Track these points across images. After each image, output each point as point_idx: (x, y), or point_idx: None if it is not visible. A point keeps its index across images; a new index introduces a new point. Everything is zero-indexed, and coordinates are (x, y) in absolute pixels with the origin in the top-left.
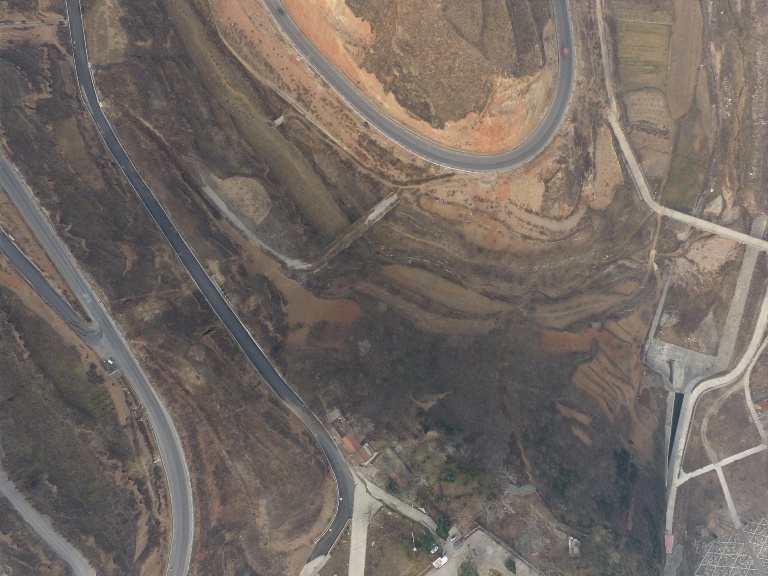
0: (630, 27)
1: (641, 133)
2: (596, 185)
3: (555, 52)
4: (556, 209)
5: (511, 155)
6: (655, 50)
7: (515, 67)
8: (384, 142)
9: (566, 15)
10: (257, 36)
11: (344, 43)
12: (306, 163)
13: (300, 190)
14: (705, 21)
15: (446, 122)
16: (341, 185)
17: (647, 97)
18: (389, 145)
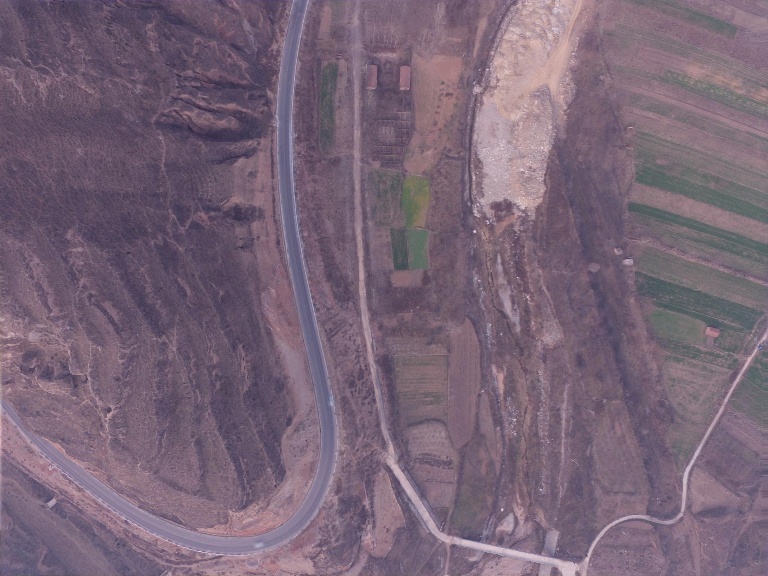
0: (407, 361)
1: (424, 466)
2: (376, 532)
3: (316, 423)
4: (332, 570)
5: (277, 533)
6: (434, 381)
7: (245, 498)
8: (147, 536)
9: (325, 383)
10: (8, 448)
11: (84, 468)
12: (85, 538)
13: (81, 565)
14: (483, 346)
15: (197, 528)
16: (123, 553)
17: (428, 430)
18: (152, 538)
